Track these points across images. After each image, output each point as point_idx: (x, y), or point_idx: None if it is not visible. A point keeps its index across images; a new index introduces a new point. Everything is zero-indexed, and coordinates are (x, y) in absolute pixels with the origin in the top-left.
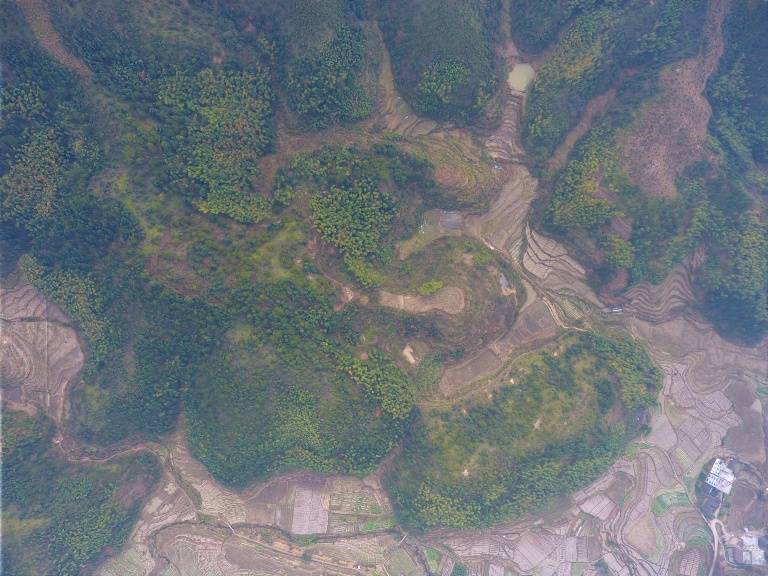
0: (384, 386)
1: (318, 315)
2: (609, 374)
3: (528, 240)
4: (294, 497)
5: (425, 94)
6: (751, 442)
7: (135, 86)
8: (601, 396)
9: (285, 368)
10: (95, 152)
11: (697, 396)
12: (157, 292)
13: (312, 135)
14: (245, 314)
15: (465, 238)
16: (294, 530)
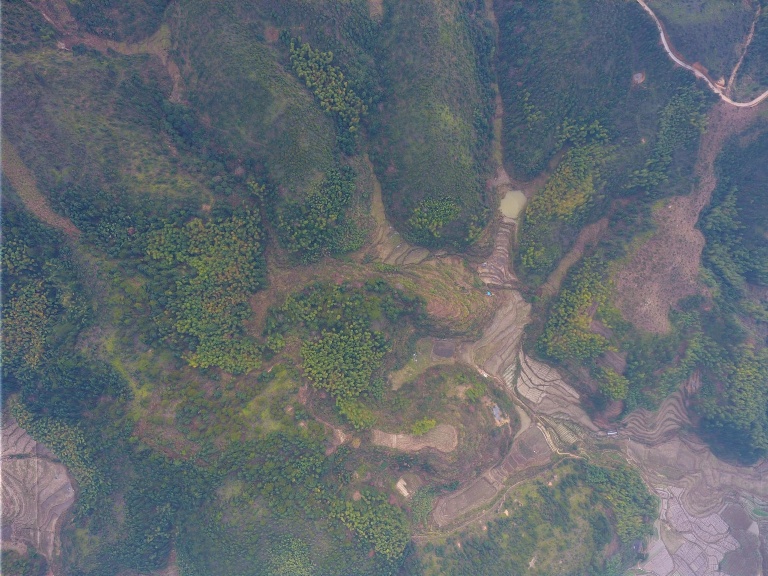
0: (377, 530)
1: (310, 462)
2: (604, 507)
3: (522, 365)
4: None
5: (416, 229)
6: (748, 566)
7: (123, 244)
8: (596, 533)
9: (276, 521)
10: (83, 308)
11: (693, 519)
12: (146, 453)
13: (303, 269)
14: (235, 471)
15: (458, 366)
16: None
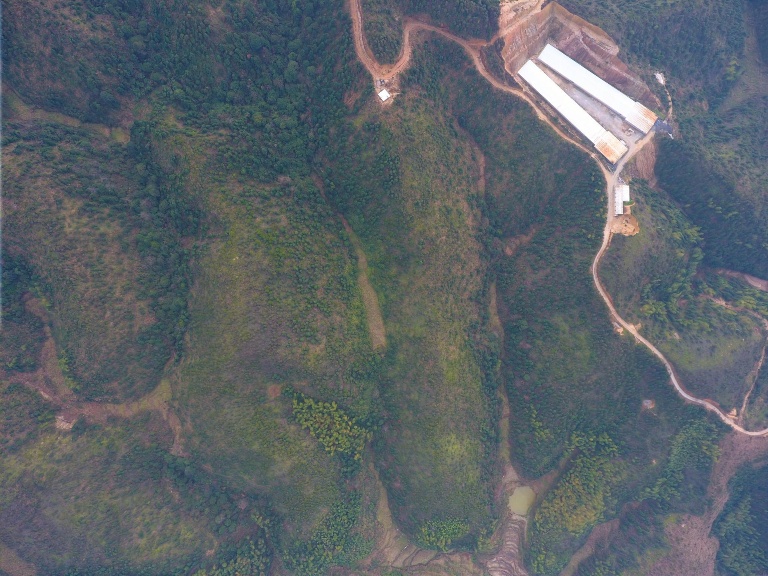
0: None
1: None
2: None
3: None
4: None
5: None
6: None
7: None
8: None
9: None
10: None
11: None
12: None
13: None
14: None
15: None
16: None
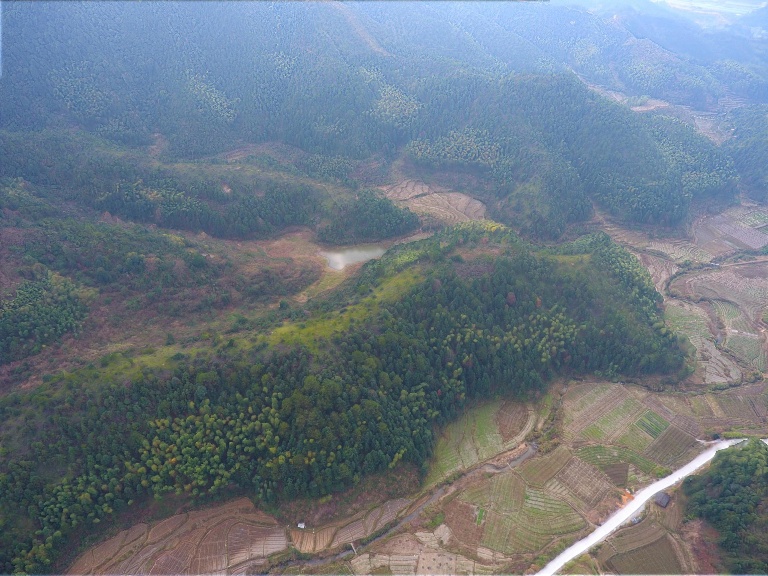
0: None
1: None
2: None
3: None
4: (720, 230)
5: (544, 70)
6: None
7: None
8: None
9: None
10: None
11: None
12: (532, 91)
13: None
14: None
15: None
16: (753, 247)
